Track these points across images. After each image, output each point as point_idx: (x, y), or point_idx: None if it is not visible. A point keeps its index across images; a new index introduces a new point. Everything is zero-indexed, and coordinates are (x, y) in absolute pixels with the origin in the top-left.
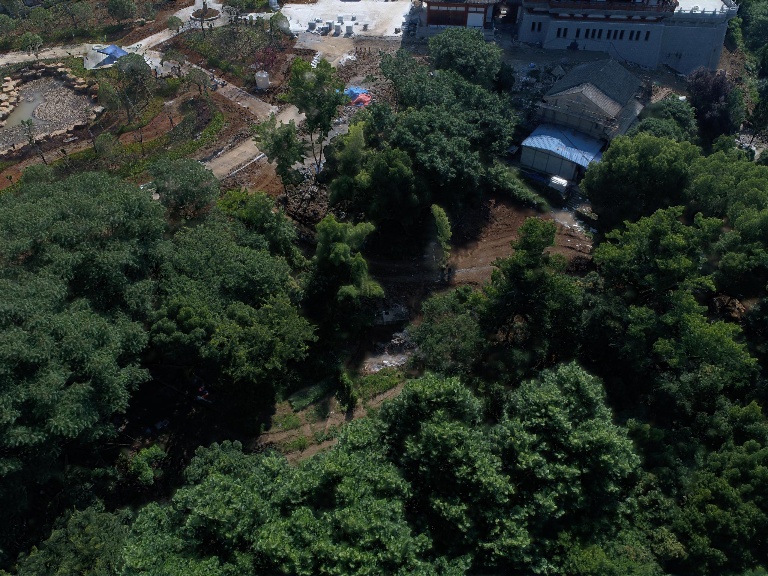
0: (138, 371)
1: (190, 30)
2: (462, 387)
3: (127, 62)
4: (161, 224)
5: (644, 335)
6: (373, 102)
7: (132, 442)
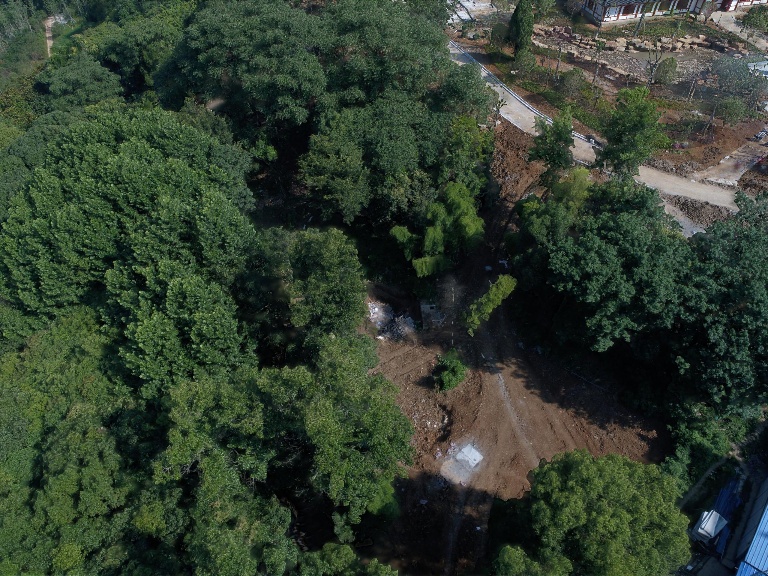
0: (301, 114)
1: None
2: (240, 259)
3: (722, 62)
4: (393, 73)
5: (231, 381)
6: None
7: None
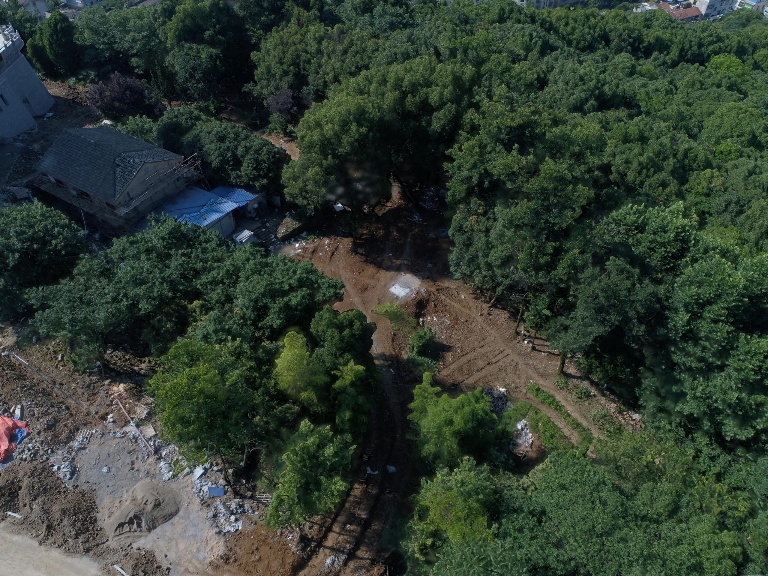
0: None
1: None
2: None
3: None
4: None
5: None
6: (202, 335)
7: None
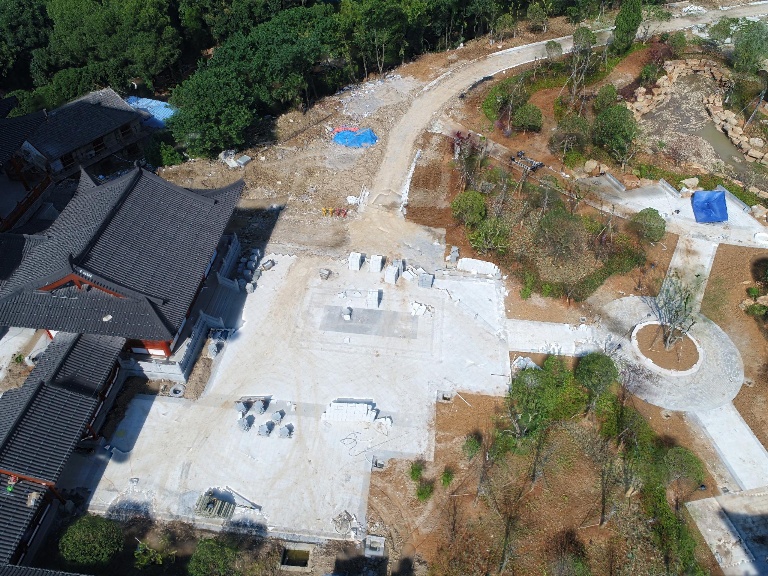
0: None
1: (652, 284)
2: None
3: None
4: None
5: None
6: None
7: (458, 34)
